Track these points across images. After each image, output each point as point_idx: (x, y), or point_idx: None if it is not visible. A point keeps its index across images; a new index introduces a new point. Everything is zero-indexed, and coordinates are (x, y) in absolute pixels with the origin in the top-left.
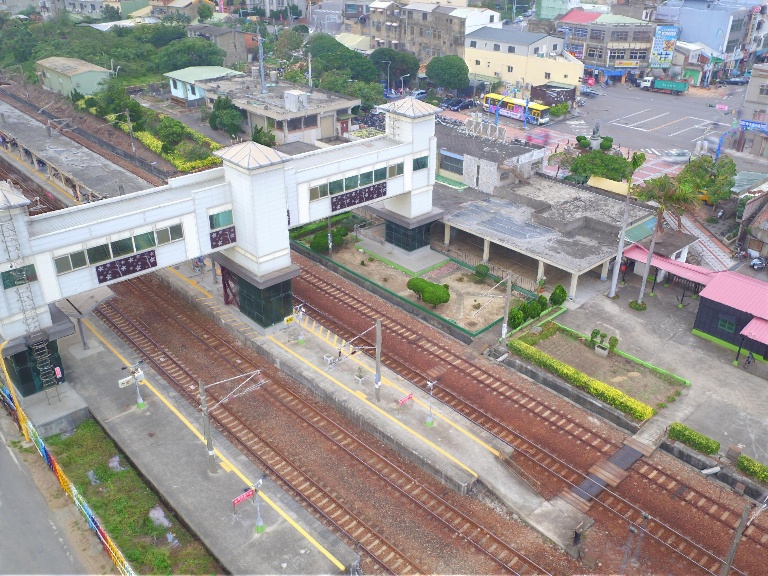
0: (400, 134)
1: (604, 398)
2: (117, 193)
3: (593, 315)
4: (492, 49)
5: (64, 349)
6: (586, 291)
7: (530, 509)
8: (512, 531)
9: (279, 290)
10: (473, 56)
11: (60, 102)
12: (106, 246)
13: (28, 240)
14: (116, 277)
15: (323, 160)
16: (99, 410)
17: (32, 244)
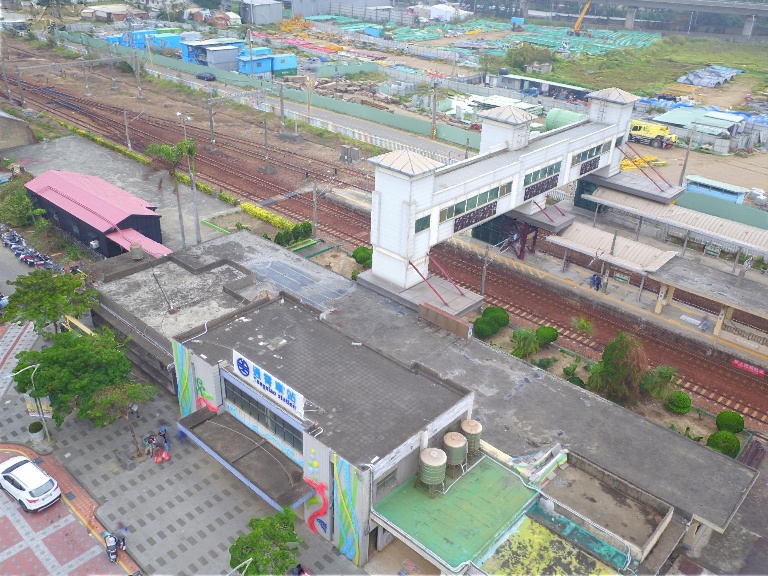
0: None
1: None
2: (759, 292)
3: None
4: None
5: None
6: None
7: None
8: None
9: None
10: None
11: None
12: None
13: None
14: None
15: (478, 169)
16: None
17: None
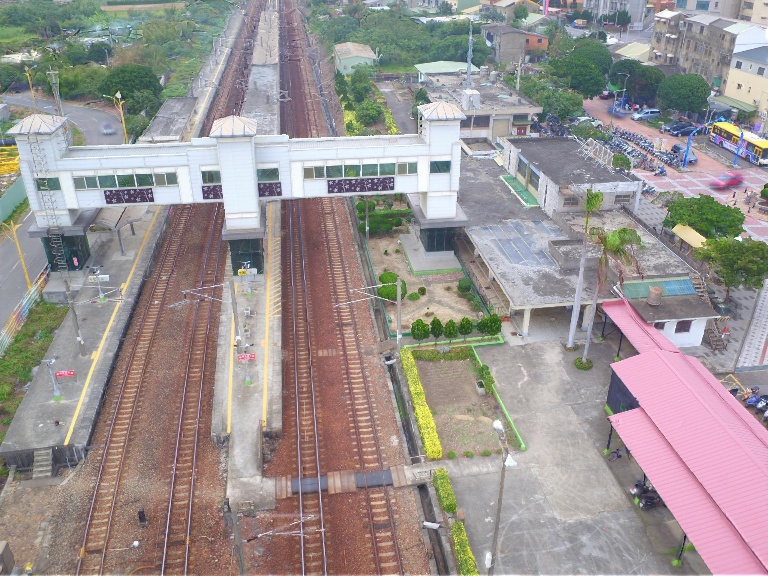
0: (426, 135)
1: (418, 424)
2: None
3: (523, 356)
4: (756, 72)
5: (113, 251)
6: (548, 333)
7: (240, 475)
8: (210, 483)
9: (249, 247)
10: (736, 78)
11: (333, 80)
12: (113, 177)
13: (55, 160)
14: (120, 202)
15: (333, 146)
16: (81, 294)
17: (58, 163)
